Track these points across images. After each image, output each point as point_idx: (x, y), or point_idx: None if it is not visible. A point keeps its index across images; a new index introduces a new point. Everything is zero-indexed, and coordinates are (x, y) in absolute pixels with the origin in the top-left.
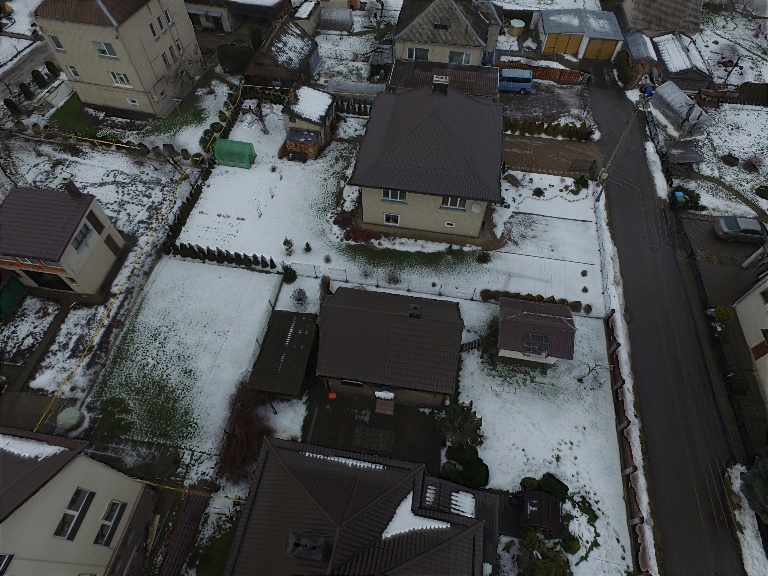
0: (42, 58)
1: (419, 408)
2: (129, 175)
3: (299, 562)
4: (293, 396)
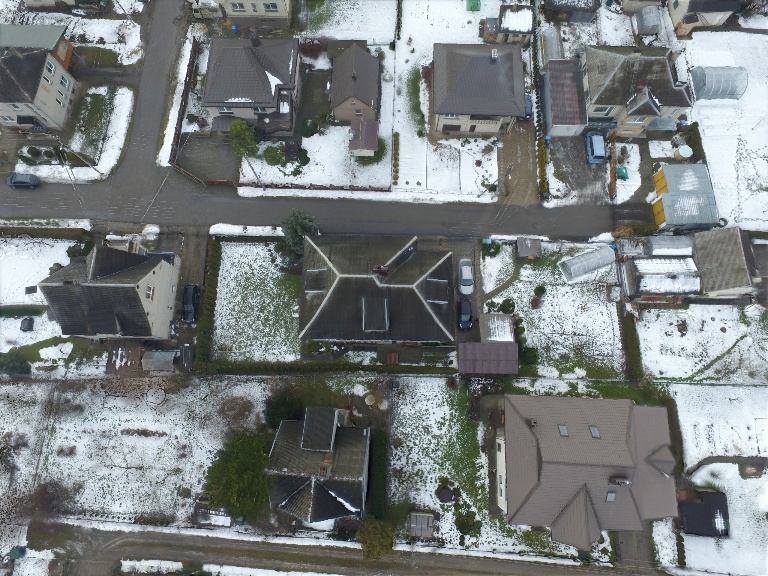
0: None
1: None
2: None
3: None
4: None
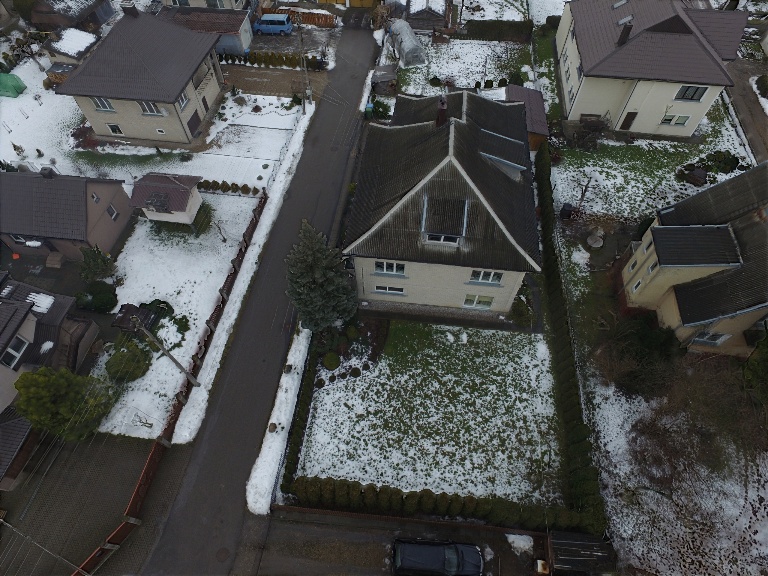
0: None
1: None
2: None
3: None
4: None
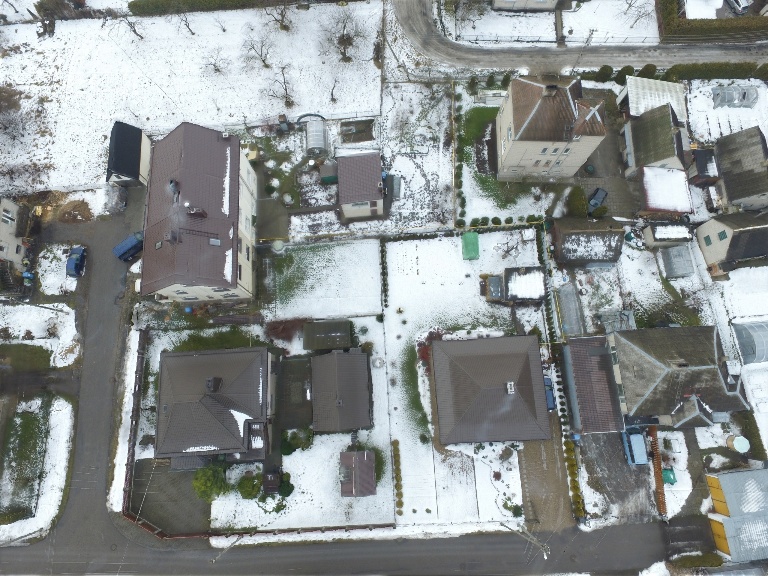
0: (537, 61)
1: None
2: (436, 187)
3: None
4: None
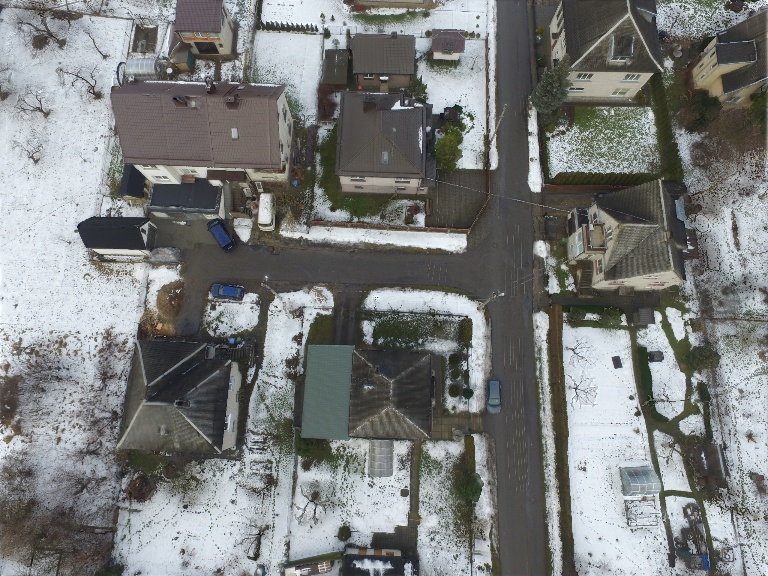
0: None
1: (400, 88)
2: None
3: (366, 113)
4: (342, 89)
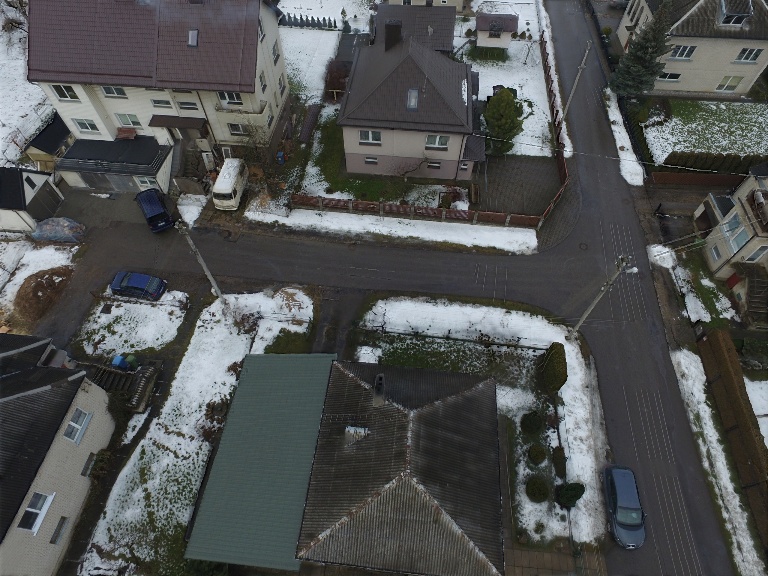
0: None
1: None
2: None
3: None
4: None
